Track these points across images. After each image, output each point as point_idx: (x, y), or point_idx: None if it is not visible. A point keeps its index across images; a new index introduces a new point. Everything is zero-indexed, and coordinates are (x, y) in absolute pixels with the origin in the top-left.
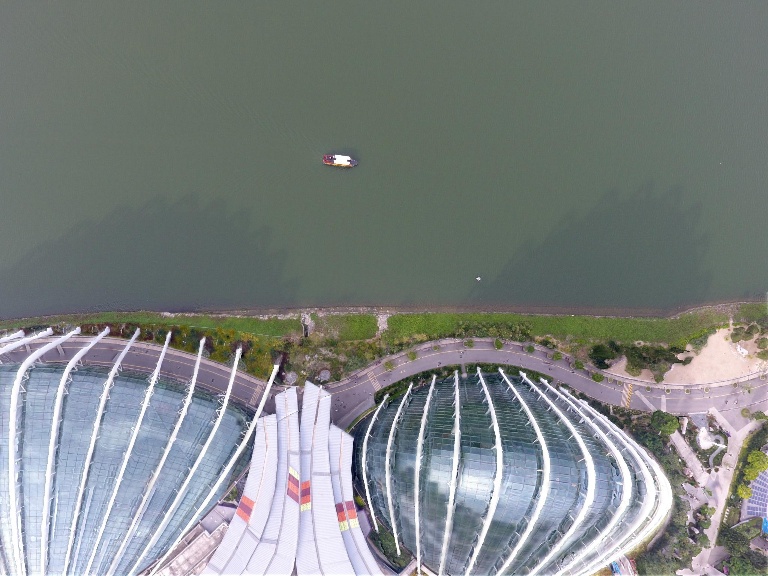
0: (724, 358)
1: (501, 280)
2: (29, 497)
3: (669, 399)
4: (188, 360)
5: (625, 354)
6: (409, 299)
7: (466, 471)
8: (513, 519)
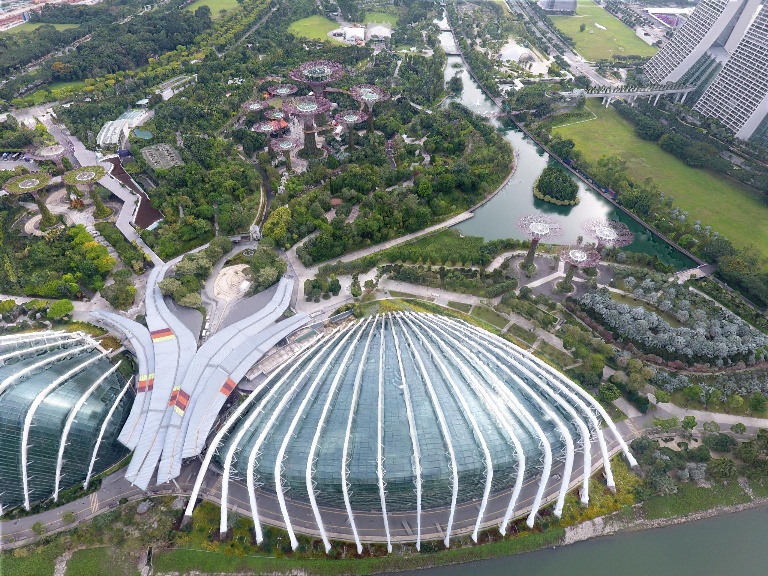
0: None
1: None
2: (373, 384)
3: None
4: (279, 520)
5: None
6: None
7: None
8: None
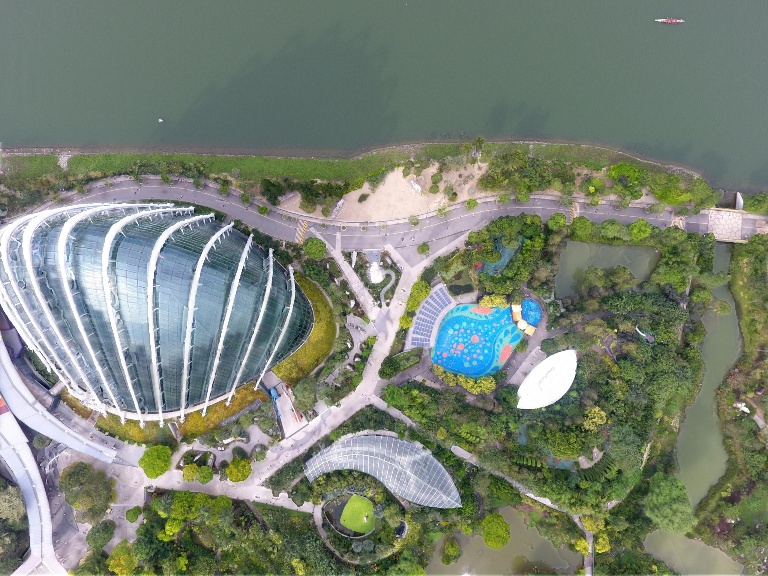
0: (402, 196)
1: (184, 122)
2: None
3: (344, 236)
4: None
5: (296, 190)
6: (93, 141)
7: (19, 248)
8: (66, 296)
